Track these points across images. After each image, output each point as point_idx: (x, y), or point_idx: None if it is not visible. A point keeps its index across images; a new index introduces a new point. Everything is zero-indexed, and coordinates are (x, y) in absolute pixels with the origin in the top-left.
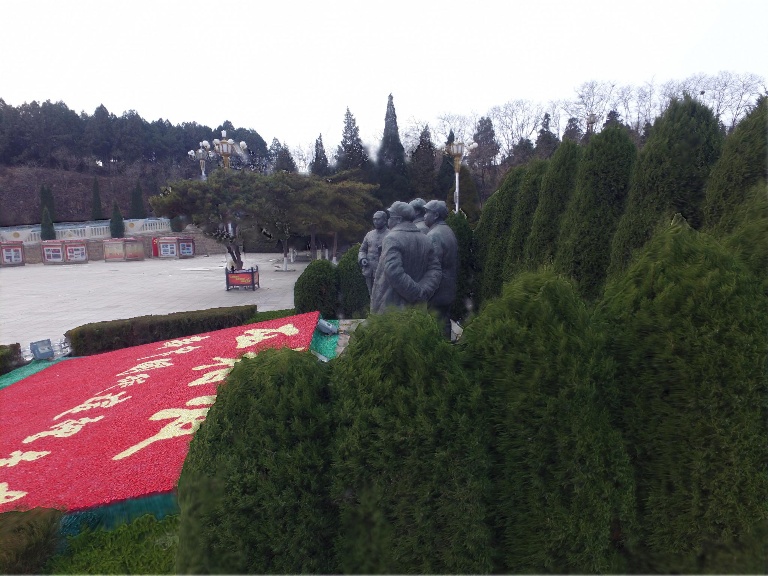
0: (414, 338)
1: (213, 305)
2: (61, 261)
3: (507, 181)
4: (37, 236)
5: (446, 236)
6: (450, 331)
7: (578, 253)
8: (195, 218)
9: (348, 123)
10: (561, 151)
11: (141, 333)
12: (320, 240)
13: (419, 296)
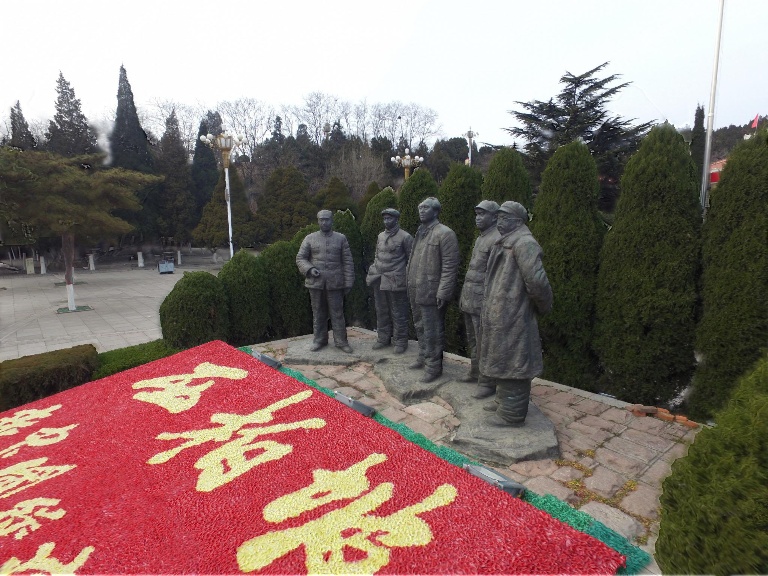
0: None
1: None
2: None
3: (413, 182)
4: None
5: None
6: None
7: (566, 253)
8: None
9: (63, 93)
10: (506, 158)
11: None
12: (38, 245)
13: (550, 307)
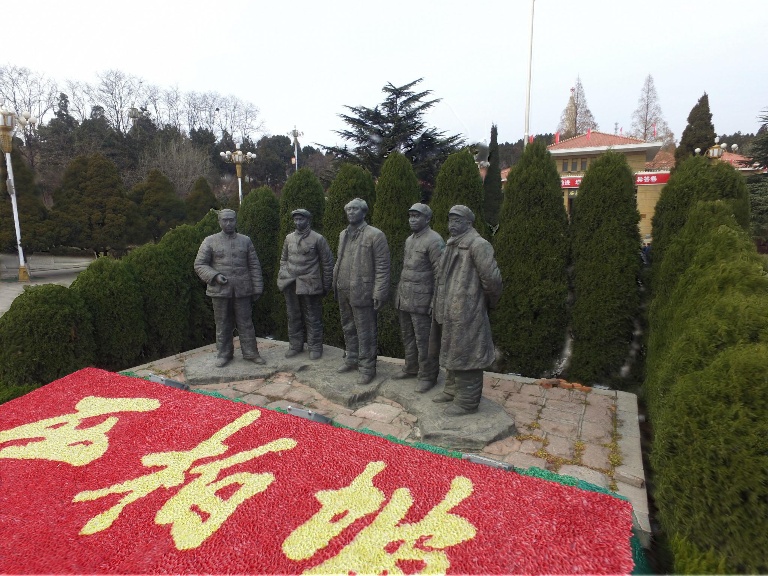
0: None
1: None
2: None
3: (298, 182)
4: None
5: None
6: None
7: None
8: None
9: None
10: (399, 162)
11: None
12: None
13: None
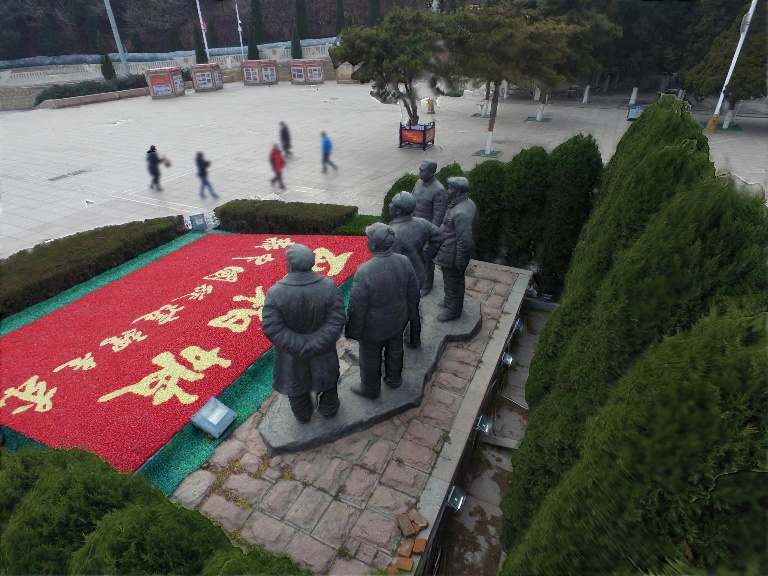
0: (21, 536)
1: (370, 170)
2: (303, 81)
3: (638, 119)
4: (289, 53)
5: (375, 275)
6: (398, 358)
7: (565, 325)
8: (360, 76)
9: None
10: (654, 131)
11: (261, 220)
12: None
13: (299, 354)
